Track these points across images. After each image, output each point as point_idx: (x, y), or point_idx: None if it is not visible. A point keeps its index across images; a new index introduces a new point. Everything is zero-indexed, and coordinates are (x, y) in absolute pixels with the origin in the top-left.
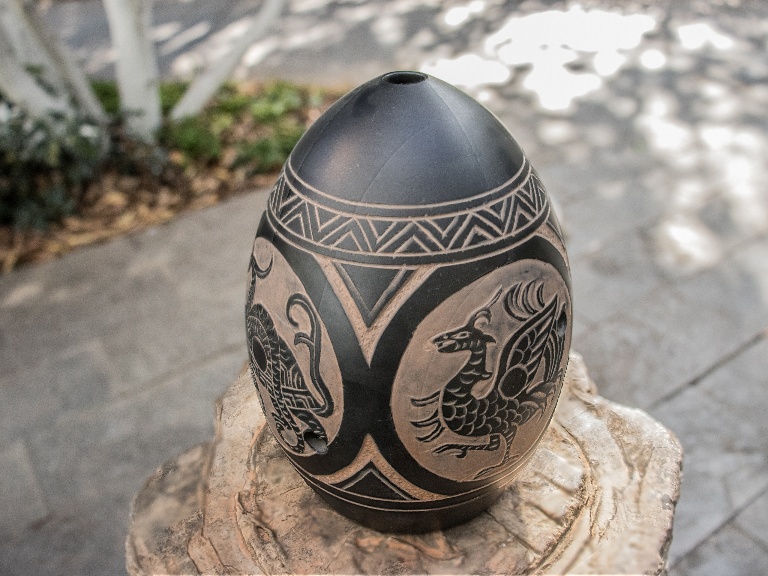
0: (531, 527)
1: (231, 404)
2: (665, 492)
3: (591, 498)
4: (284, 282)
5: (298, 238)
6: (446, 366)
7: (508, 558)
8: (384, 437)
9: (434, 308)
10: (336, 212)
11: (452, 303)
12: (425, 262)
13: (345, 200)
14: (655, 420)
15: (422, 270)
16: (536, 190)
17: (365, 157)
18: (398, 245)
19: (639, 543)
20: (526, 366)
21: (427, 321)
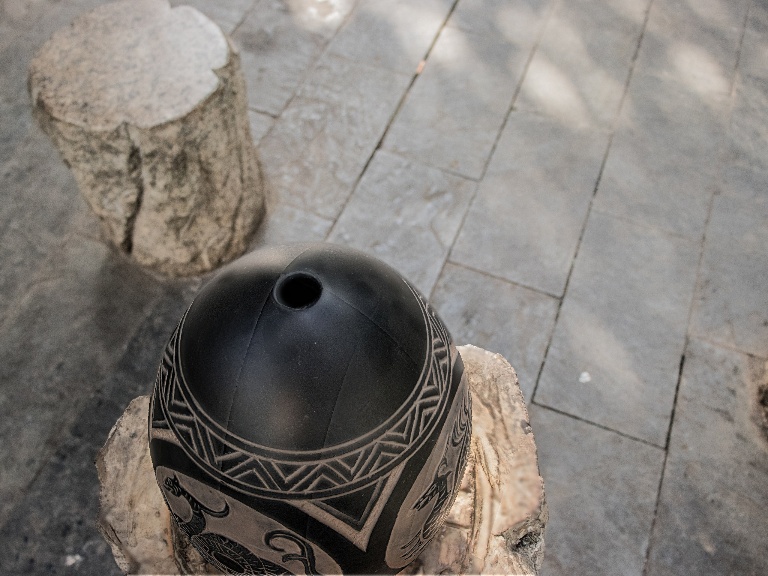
0: (452, 508)
1: (118, 519)
2: (521, 418)
3: (476, 453)
4: (254, 524)
5: (261, 491)
6: (424, 514)
7: (451, 546)
8: (379, 574)
9: (410, 489)
10: (300, 463)
11: (421, 476)
12: (396, 465)
13: (306, 451)
14: (484, 349)
15: (394, 471)
16: (436, 324)
17: (311, 406)
18: (371, 466)
19: (525, 475)
20: (465, 460)
21: (406, 500)
